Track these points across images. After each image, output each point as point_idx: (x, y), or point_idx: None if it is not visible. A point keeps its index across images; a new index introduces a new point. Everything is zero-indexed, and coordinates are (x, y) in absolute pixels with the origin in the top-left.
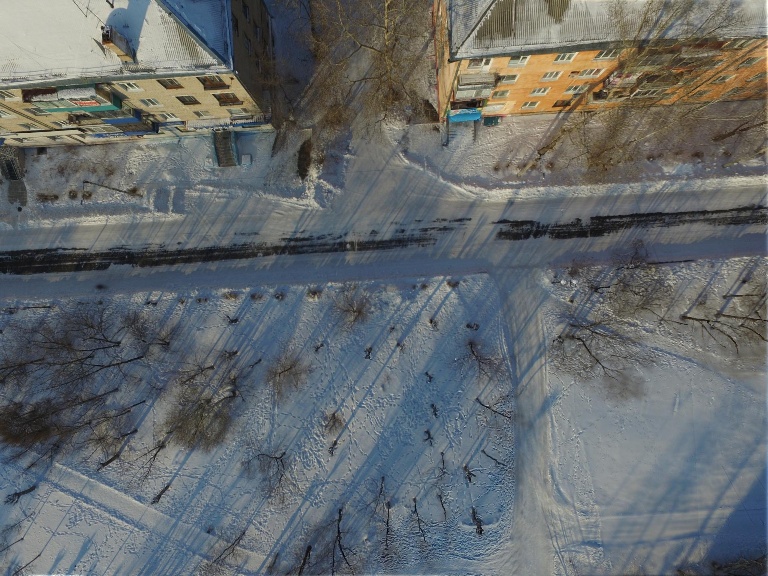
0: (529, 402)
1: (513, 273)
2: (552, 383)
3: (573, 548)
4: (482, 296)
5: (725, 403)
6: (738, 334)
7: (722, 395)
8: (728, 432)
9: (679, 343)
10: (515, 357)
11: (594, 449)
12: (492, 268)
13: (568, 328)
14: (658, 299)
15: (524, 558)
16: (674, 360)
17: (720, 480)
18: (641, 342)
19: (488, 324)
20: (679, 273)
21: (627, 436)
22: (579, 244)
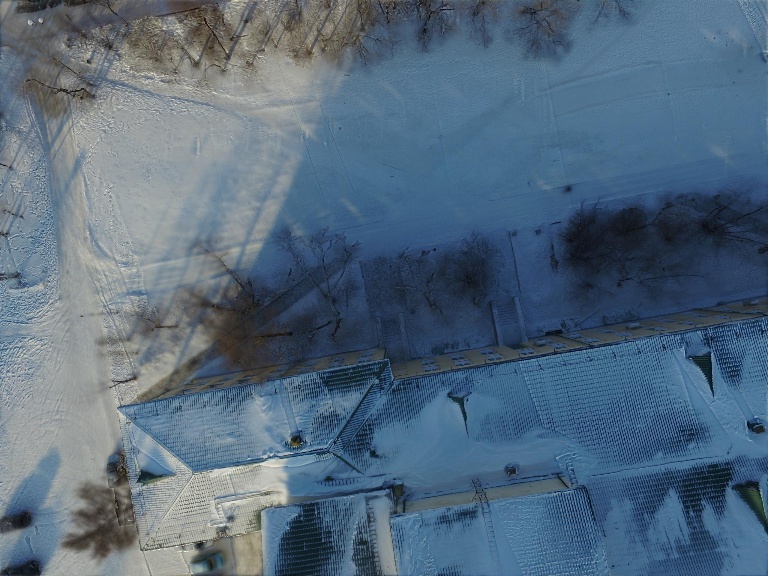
0: (63, 165)
1: (34, 44)
2: (80, 143)
3: (119, 300)
4: (5, 68)
5: (243, 140)
6: (248, 73)
7: (239, 133)
8: (249, 168)
9: (195, 89)
10: (45, 124)
11: (126, 201)
12: (14, 41)
13: (88, 88)
14: (170, 49)
15: (75, 316)
16: (191, 106)
17: (248, 215)
18: (160, 93)
19: (14, 94)
20: (185, 21)
21: (154, 184)
22: (93, 8)
